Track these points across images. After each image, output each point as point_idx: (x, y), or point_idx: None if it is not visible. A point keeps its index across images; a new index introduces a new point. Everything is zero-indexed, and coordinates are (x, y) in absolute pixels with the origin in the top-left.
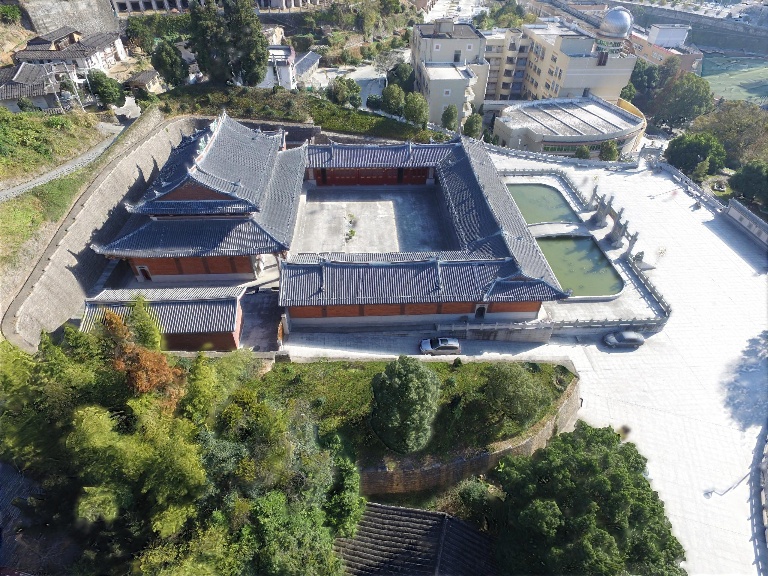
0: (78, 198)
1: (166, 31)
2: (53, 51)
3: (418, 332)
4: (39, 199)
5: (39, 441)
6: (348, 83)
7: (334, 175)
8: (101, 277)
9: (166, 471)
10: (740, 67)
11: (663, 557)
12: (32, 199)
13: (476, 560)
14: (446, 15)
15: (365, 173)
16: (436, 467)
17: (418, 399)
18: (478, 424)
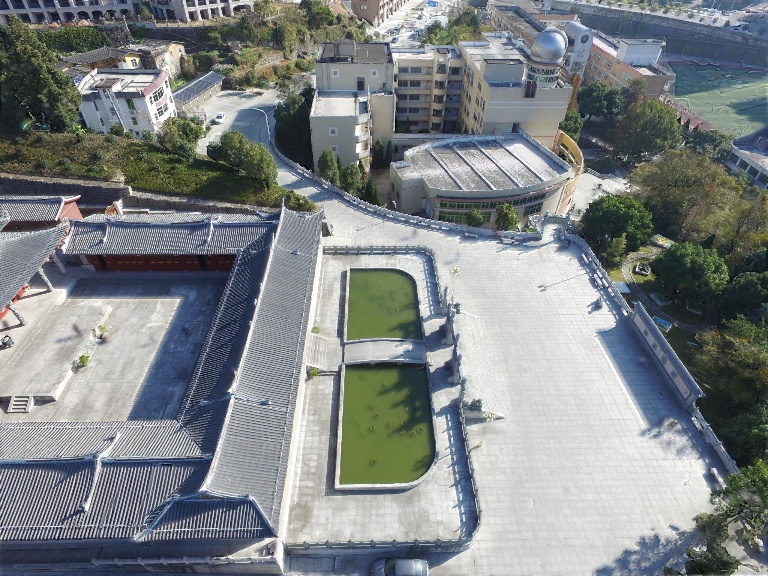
0: None
1: None
2: None
3: (66, 566)
4: None
5: None
6: (182, 127)
7: (114, 260)
8: None
9: None
10: (733, 83)
11: None
12: None
13: None
14: (402, 24)
15: (155, 257)
16: None
17: None
18: None
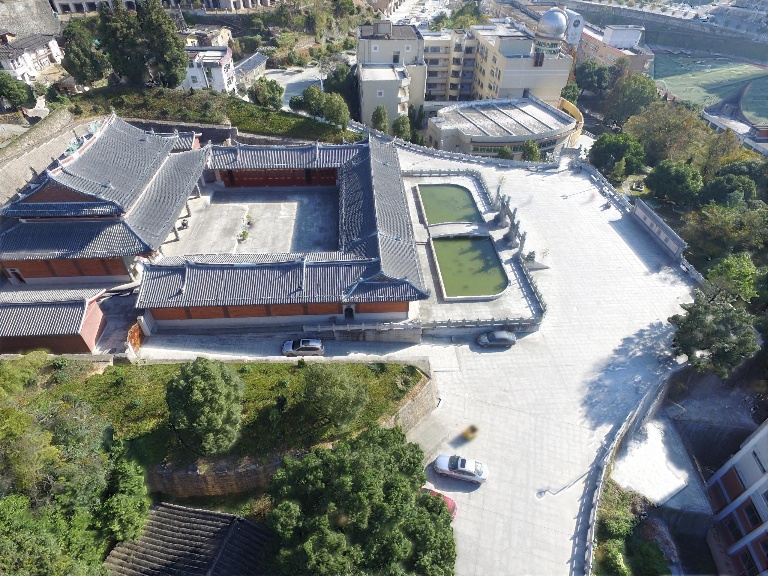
0: None
1: None
2: None
3: (284, 333)
4: None
5: None
6: (270, 84)
7: (241, 176)
8: None
9: None
10: (703, 68)
11: (431, 557)
12: None
13: (259, 562)
14: (408, 16)
15: (273, 174)
16: (251, 469)
17: (205, 401)
18: (305, 425)
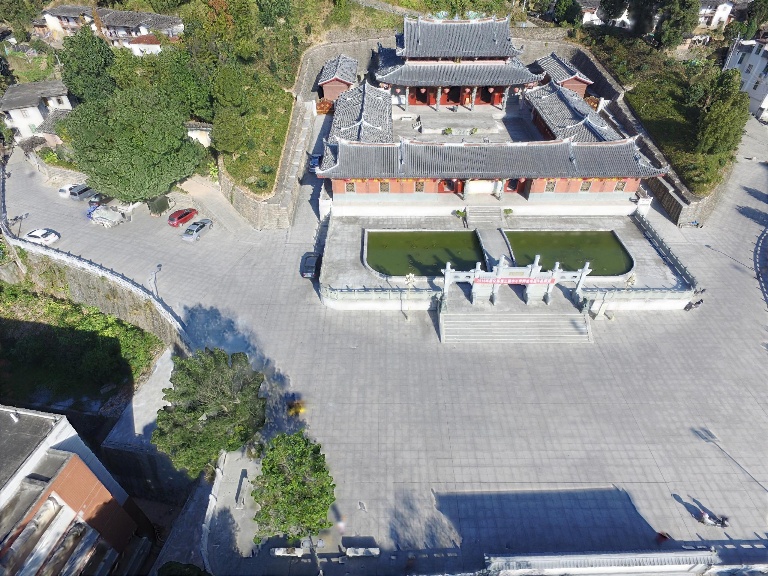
0: None
1: None
2: None
3: None
4: None
5: None
6: (724, 76)
7: None
8: None
9: None
10: None
11: None
12: None
13: None
14: None
15: None
16: None
17: None
18: None
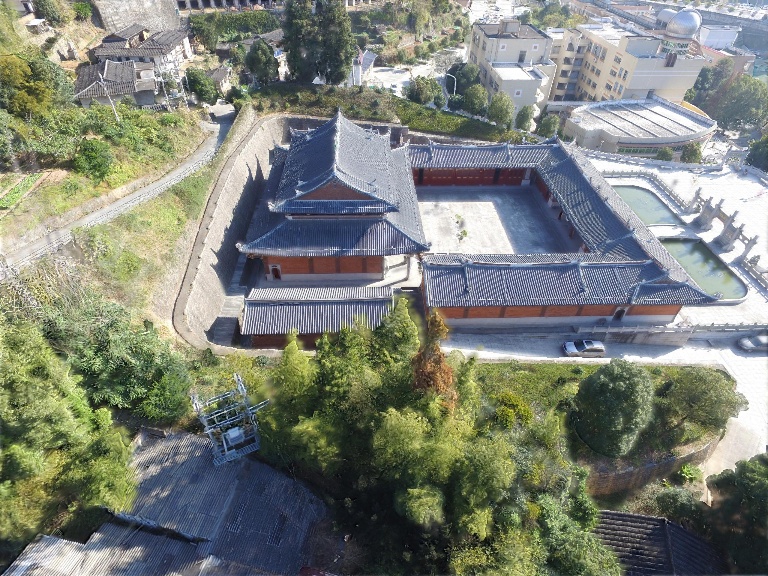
0: (209, 196)
1: (225, 29)
2: (131, 49)
3: (558, 334)
4: (178, 197)
5: (338, 442)
6: (430, 83)
7: (431, 175)
8: (234, 275)
9: (478, 474)
10: None
11: None
12: (173, 197)
13: (704, 565)
14: (486, 15)
15: (462, 173)
16: (629, 471)
17: (641, 403)
18: (659, 428)
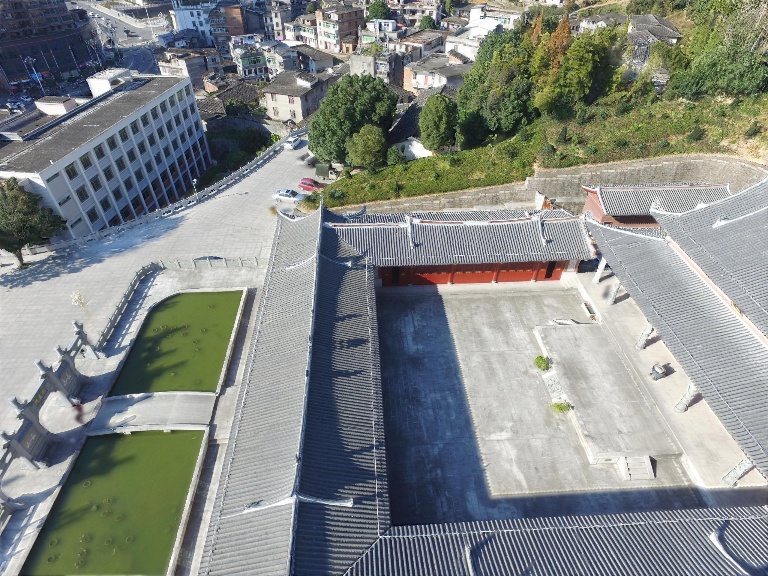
0: None
1: None
2: None
3: None
4: None
5: None
6: None
7: None
8: None
9: None
10: None
11: None
12: None
13: None
14: None
15: None
16: None
17: None
18: None
